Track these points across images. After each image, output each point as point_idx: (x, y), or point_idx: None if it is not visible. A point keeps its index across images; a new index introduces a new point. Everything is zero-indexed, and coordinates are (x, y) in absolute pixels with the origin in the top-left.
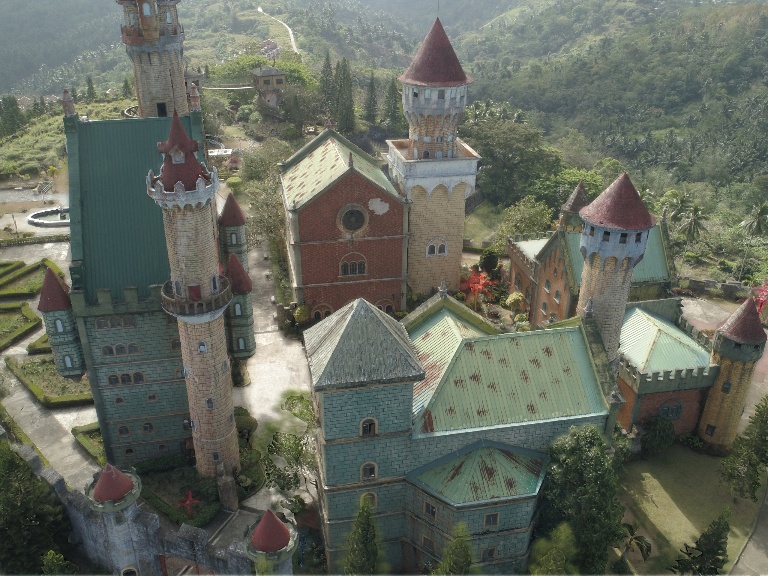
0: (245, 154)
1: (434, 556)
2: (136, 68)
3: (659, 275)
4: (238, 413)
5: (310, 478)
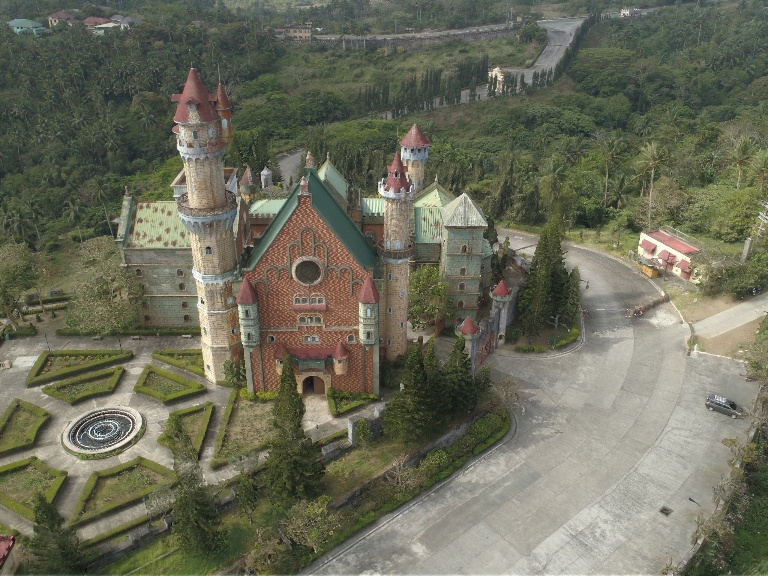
0: (4, 271)
1: (484, 287)
2: (212, 169)
3: (345, 184)
4: None
5: (436, 307)
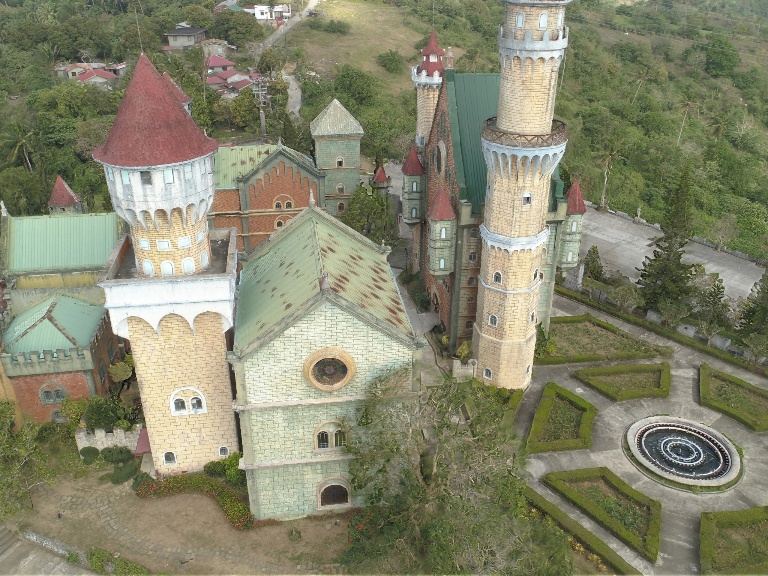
0: None
1: None
2: None
3: None
4: (424, 294)
5: None
